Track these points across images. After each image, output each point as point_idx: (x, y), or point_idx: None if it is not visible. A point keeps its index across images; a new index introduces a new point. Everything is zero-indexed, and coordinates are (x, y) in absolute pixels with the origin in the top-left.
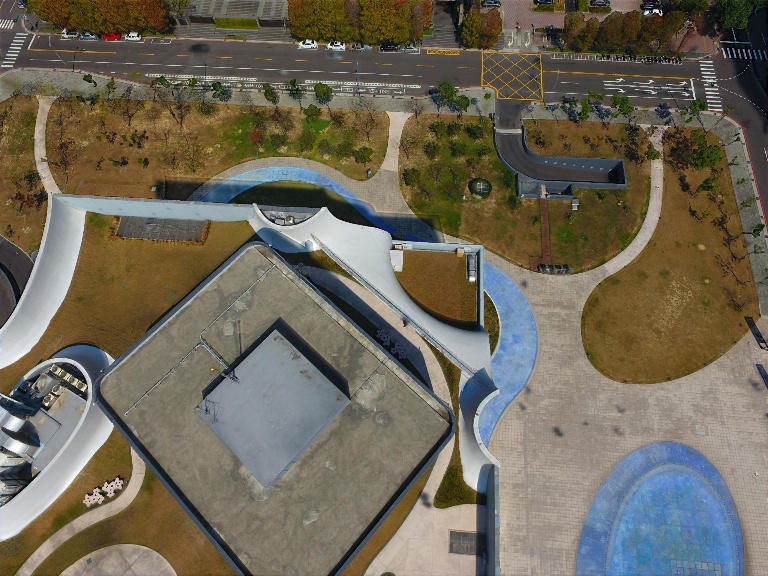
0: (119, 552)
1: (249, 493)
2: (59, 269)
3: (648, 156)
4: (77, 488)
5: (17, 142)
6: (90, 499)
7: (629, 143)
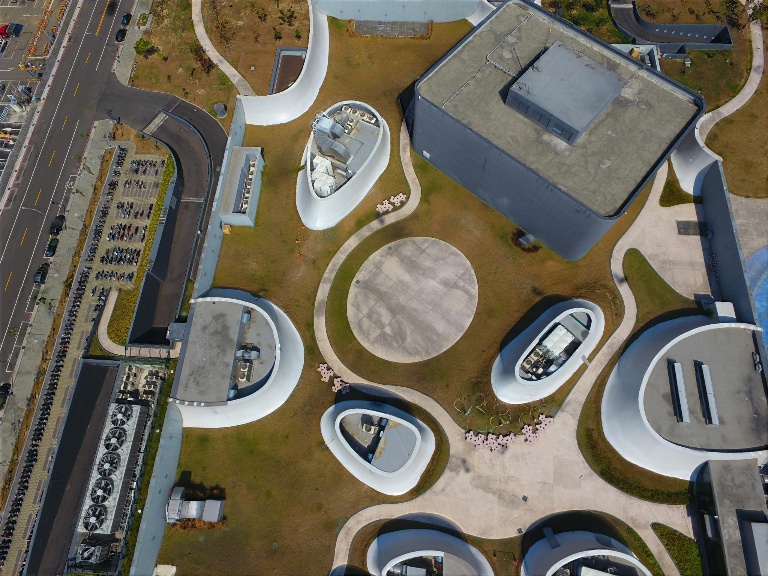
0: (413, 242)
1: (554, 151)
2: (319, 52)
3: (754, 16)
4: (370, 200)
5: (178, 23)
6: (382, 207)
7: (730, 14)
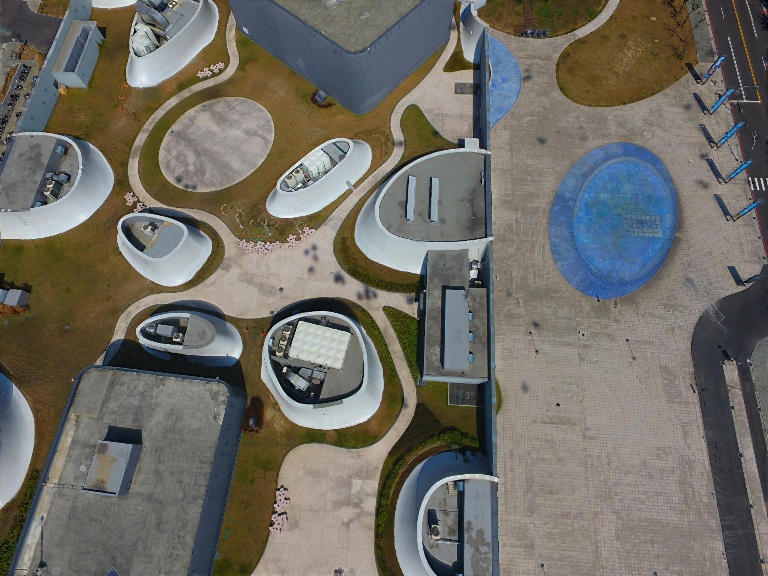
0: (225, 101)
1: (324, 6)
2: None
3: None
4: (192, 68)
5: None
6: (202, 73)
7: None
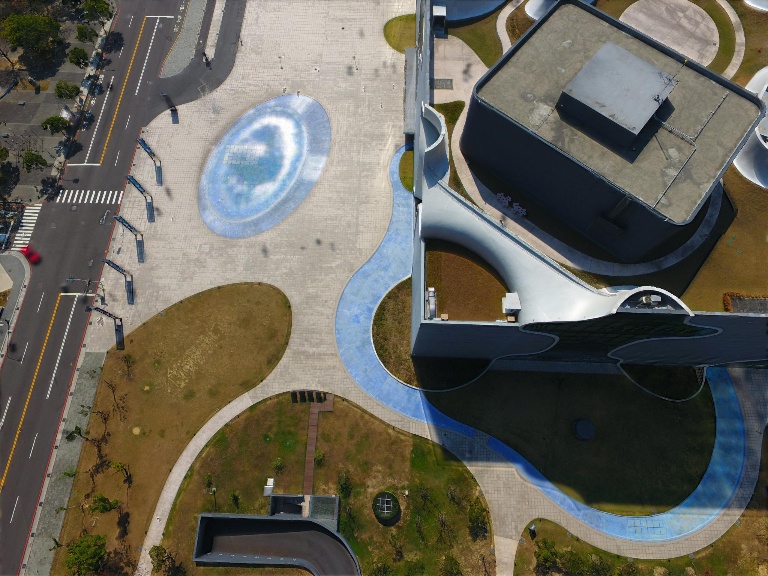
0: None
1: None
2: None
3: None
4: None
5: None
6: None
7: None
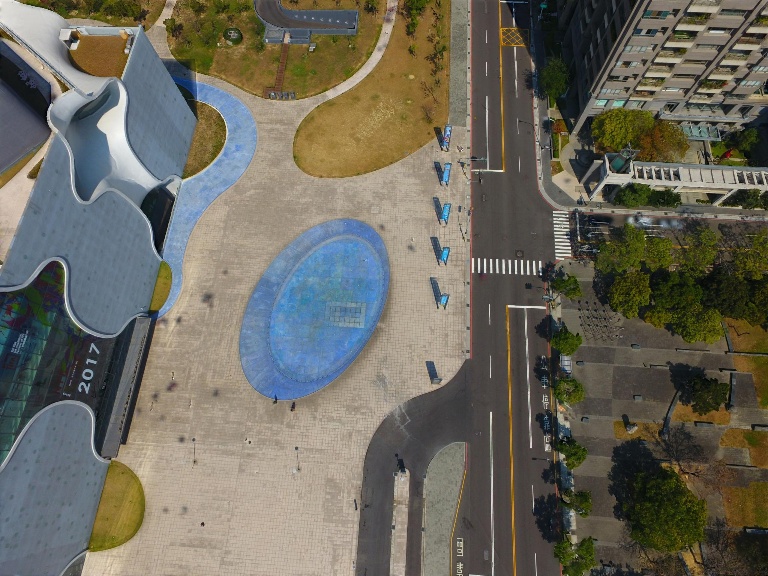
0: None
1: None
2: None
3: None
4: None
5: None
6: None
7: None
